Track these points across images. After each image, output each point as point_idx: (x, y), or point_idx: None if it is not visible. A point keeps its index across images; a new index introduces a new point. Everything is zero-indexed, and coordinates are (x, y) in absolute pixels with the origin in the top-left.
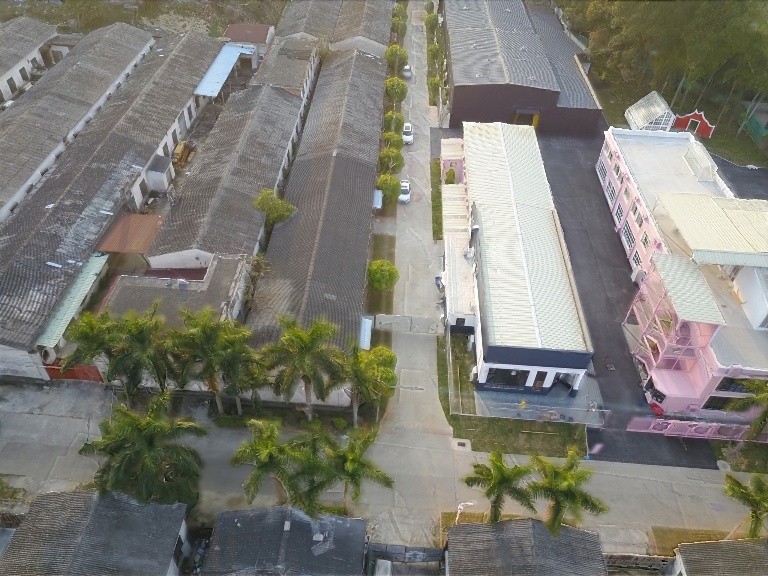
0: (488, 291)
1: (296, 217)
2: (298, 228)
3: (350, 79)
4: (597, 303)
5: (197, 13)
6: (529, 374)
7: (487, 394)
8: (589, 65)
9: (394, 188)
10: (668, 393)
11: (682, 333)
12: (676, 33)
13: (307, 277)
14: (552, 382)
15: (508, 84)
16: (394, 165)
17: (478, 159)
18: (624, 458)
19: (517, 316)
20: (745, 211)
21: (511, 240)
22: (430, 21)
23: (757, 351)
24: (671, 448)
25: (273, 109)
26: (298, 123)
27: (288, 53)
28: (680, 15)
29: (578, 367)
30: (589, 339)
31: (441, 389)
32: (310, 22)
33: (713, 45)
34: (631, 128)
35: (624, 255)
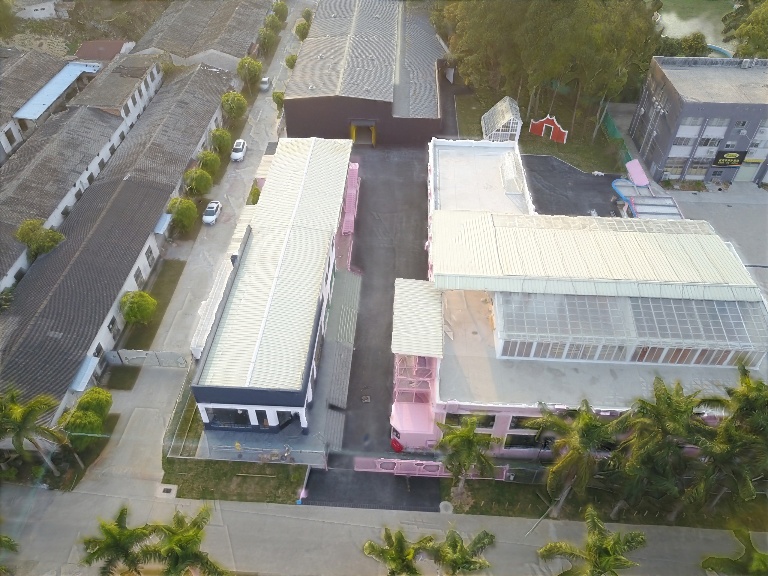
0: (223, 324)
1: (60, 247)
2: (55, 259)
3: (180, 96)
4: (377, 328)
5: (55, 31)
6: (248, 413)
7: (215, 434)
8: (453, 70)
9: (183, 211)
10: (400, 429)
11: (420, 364)
12: (515, 36)
13: (35, 314)
14: (278, 420)
15: (337, 96)
16: (198, 186)
17: (276, 178)
18: (339, 502)
19: (239, 351)
20: (518, 228)
21: (269, 266)
22: (300, 30)
23: (490, 383)
24: (396, 489)
25: (81, 131)
26: (115, 144)
27: (122, 71)
28: (511, 18)
29: (294, 405)
30: (303, 375)
31: (169, 429)
32: (166, 36)
33: (543, 49)
34: (483, 136)
35: (426, 274)
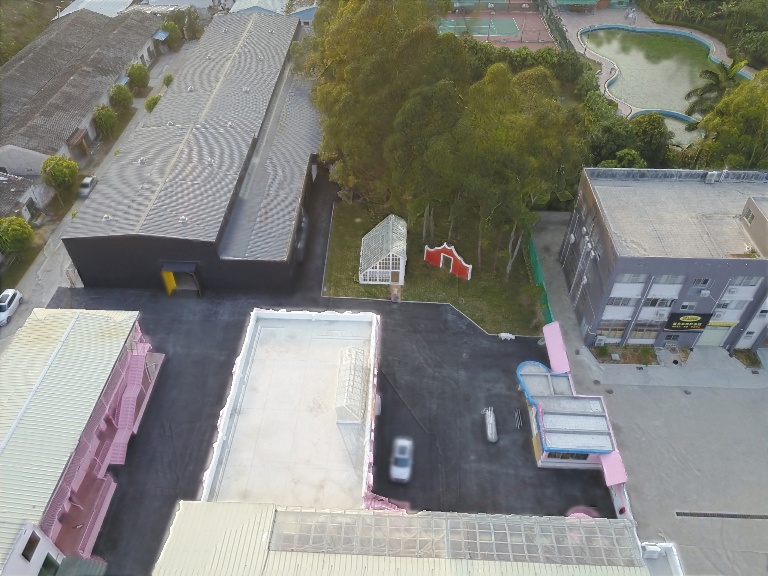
0: None
1: None
2: None
3: None
4: None
5: None
6: None
7: None
8: None
9: None
10: None
11: None
12: None
13: None
14: None
15: (134, 235)
16: None
17: None
18: None
19: None
20: (306, 555)
21: None
22: (149, 106)
23: None
24: None
25: None
26: None
27: None
28: (377, 125)
29: None
30: None
31: None
32: None
33: (418, 172)
34: None
35: None
